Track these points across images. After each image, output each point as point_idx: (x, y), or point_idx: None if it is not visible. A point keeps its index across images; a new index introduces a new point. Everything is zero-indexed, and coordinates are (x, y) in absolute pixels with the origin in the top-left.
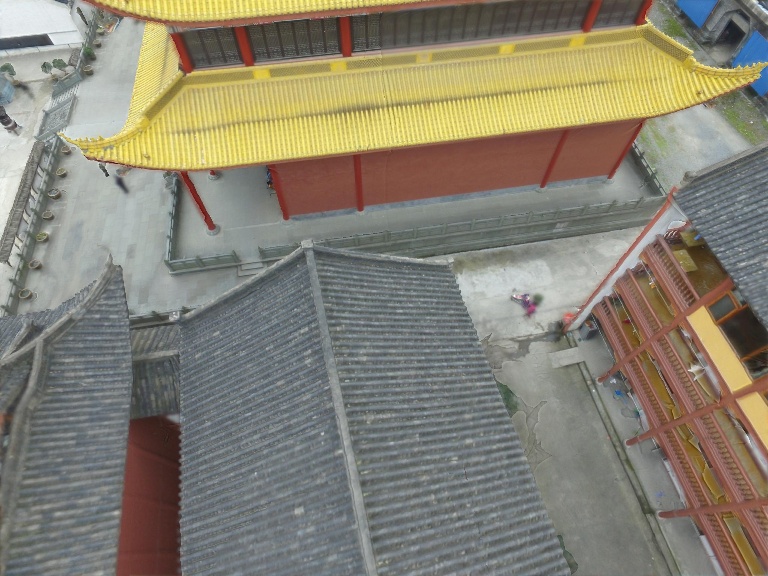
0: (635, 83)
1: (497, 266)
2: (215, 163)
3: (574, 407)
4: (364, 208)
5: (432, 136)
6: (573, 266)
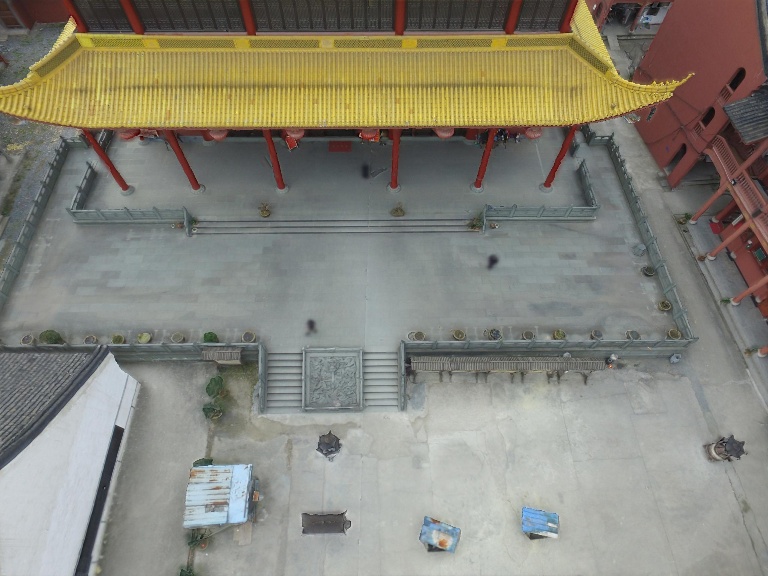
0: None
1: None
2: None
3: (644, 48)
4: None
5: None
6: None
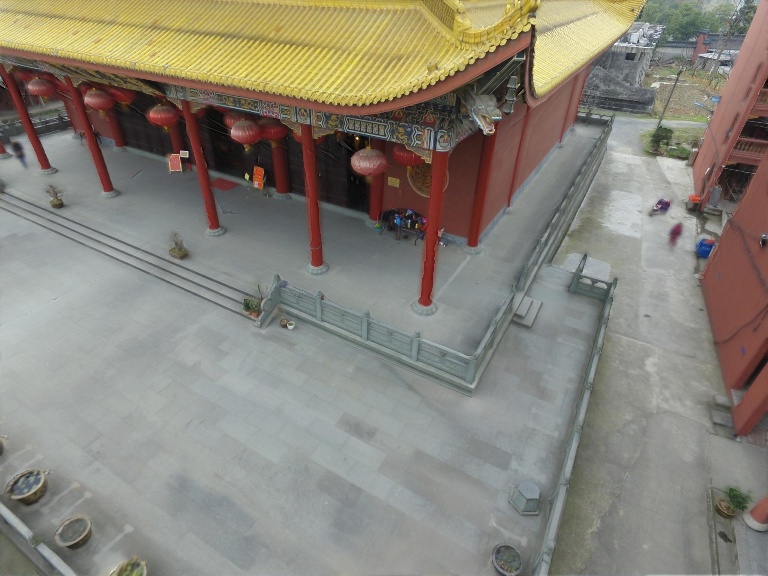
0: (603, 14)
1: (606, 207)
2: (545, 85)
3: None
4: (509, 202)
5: (598, 45)
6: (628, 184)
